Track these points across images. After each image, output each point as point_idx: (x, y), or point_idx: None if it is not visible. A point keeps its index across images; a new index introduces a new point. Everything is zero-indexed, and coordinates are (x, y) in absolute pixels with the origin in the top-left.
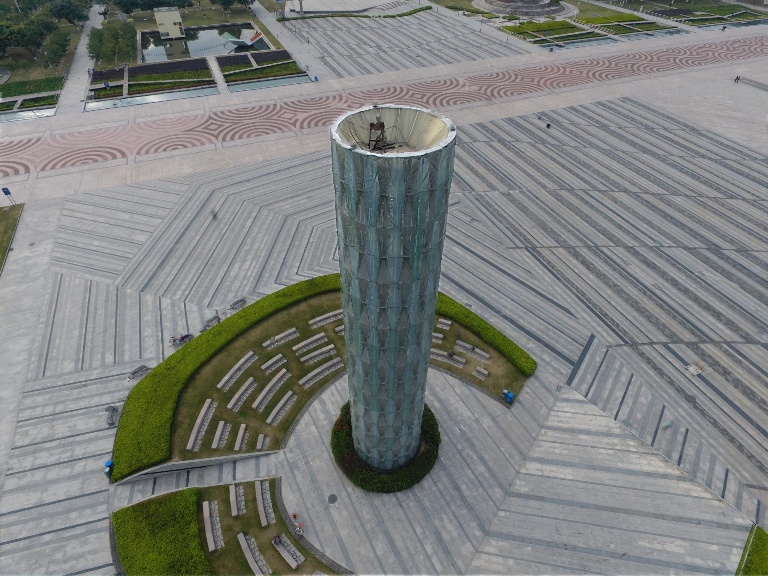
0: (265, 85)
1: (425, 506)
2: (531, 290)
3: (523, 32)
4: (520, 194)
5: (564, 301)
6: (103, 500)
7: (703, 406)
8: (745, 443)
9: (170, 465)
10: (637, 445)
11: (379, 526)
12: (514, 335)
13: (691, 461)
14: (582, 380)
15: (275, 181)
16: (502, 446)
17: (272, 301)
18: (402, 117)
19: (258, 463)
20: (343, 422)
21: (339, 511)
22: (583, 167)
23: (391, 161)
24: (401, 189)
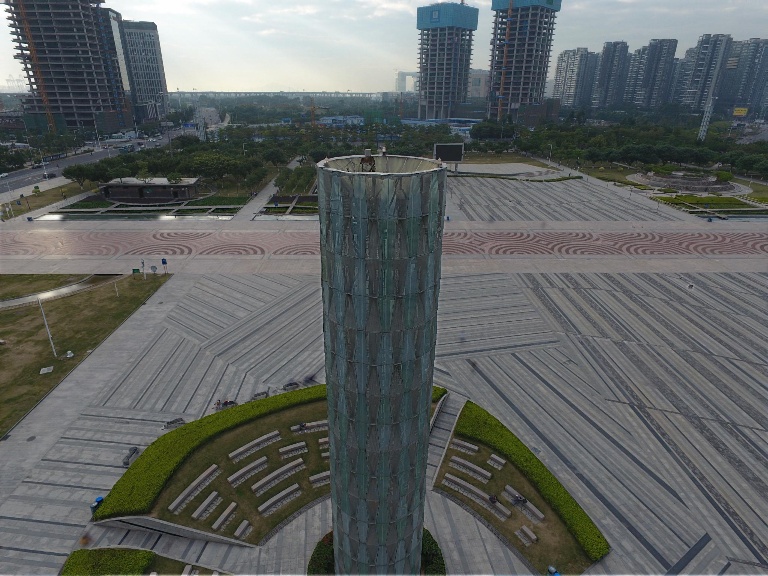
0: None
1: None
2: (625, 454)
3: (679, 203)
4: (637, 347)
5: (671, 479)
6: (75, 535)
7: None
8: None
9: (145, 519)
10: None
11: None
12: (587, 502)
13: None
14: None
15: None
16: None
17: (320, 389)
18: (407, 166)
19: (228, 552)
20: None
21: None
22: (730, 333)
23: (353, 178)
24: (364, 211)
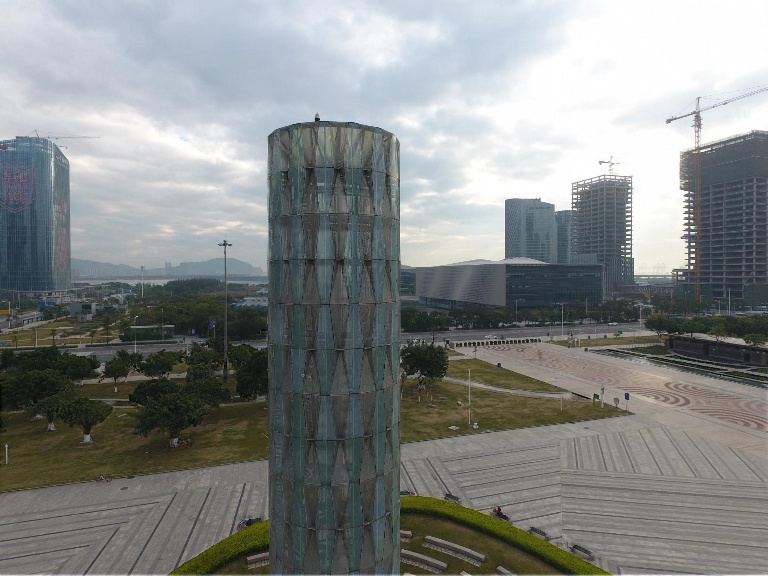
0: None
1: None
2: None
3: None
4: None
5: None
6: None
7: None
8: None
9: None
10: None
11: None
12: None
13: None
14: None
15: None
16: None
17: (590, 569)
18: None
19: None
20: None
21: None
22: None
23: None
24: None
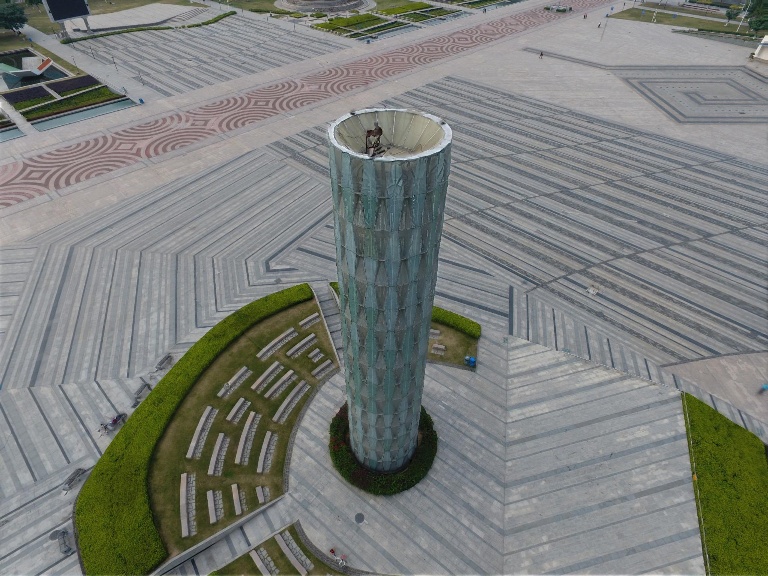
0: (81, 117)
1: (445, 486)
2: (447, 263)
3: (336, 28)
4: None
5: (477, 264)
6: None
7: (610, 317)
8: (647, 335)
9: (171, 562)
10: (582, 364)
11: (414, 523)
12: (450, 306)
13: (620, 363)
14: (519, 327)
15: (144, 220)
16: (484, 406)
17: (206, 347)
18: (380, 120)
19: (267, 517)
20: (338, 441)
21: (371, 526)
22: None
23: (415, 162)
24: (423, 188)
